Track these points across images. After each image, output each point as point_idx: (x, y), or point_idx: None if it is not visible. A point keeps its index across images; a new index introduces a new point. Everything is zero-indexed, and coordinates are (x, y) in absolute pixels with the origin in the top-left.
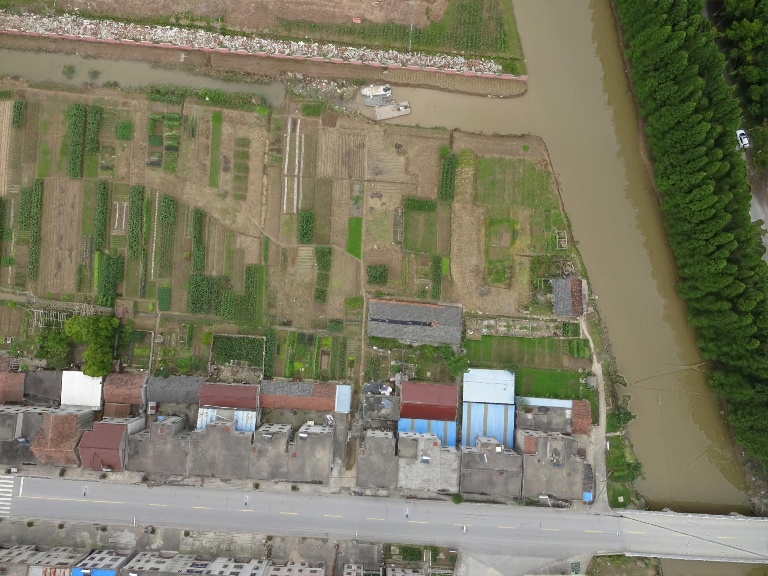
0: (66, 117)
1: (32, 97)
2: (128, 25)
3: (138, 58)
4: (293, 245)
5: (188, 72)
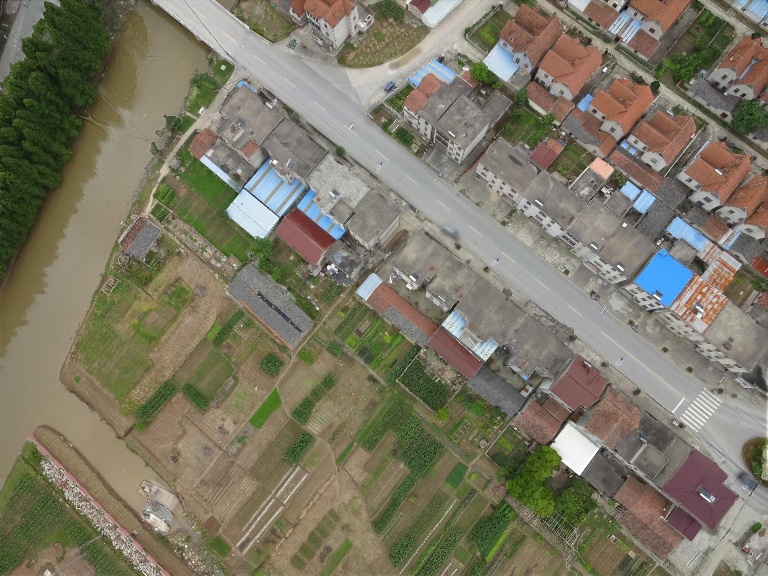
0: None
1: None
2: None
3: None
4: (321, 441)
5: None
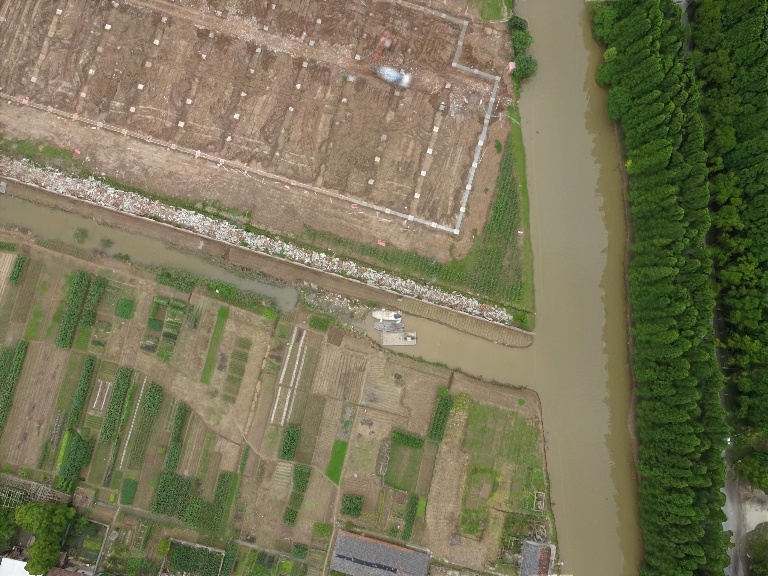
0: (68, 282)
1: (37, 255)
2: (153, 202)
3: (156, 236)
4: (273, 458)
5: (204, 260)
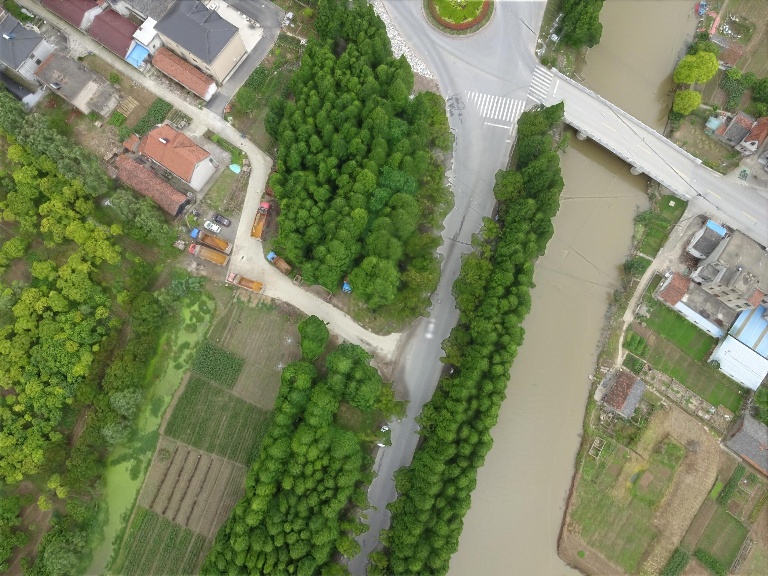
0: None
1: None
2: None
3: None
4: None
5: None
